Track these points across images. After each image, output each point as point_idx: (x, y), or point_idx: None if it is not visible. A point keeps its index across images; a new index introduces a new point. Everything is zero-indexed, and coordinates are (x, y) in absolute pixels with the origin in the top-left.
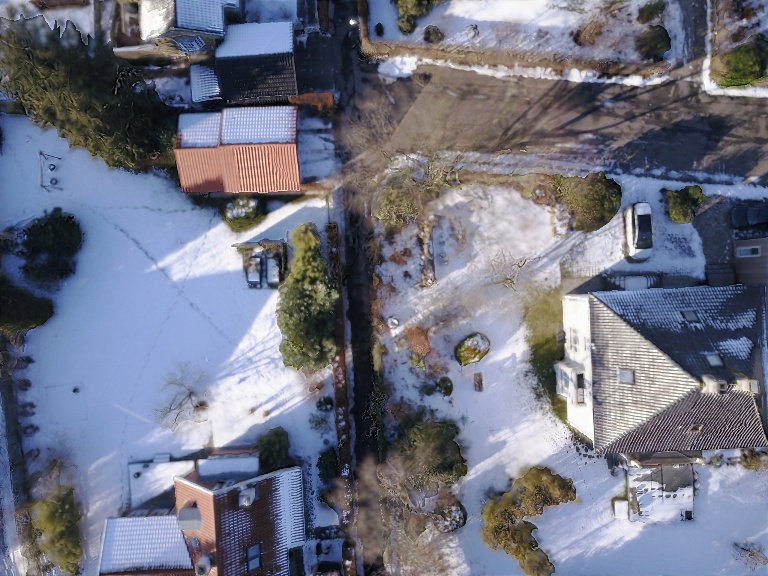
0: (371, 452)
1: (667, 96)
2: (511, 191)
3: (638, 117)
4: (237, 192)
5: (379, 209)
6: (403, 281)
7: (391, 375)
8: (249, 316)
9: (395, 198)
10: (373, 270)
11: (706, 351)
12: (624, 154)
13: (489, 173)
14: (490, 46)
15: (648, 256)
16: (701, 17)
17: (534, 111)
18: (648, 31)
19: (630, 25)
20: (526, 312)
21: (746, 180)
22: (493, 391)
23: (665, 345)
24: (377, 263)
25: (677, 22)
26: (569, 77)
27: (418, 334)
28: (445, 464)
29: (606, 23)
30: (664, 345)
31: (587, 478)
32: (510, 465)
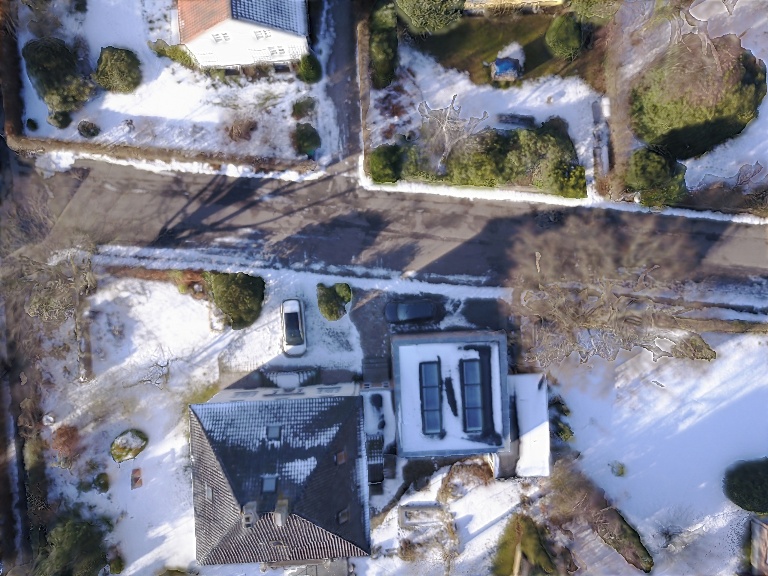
0: (40, 546)
1: (325, 191)
2: (169, 286)
3: (296, 212)
4: None
5: (29, 307)
6: (62, 377)
7: (53, 471)
8: None
9: (44, 296)
10: (34, 365)
11: (267, 474)
12: (283, 249)
13: (148, 268)
14: (146, 141)
15: (301, 352)
16: (354, 114)
17: (193, 206)
18: None
19: (285, 121)
20: (185, 407)
21: (403, 274)
22: (152, 487)
23: (231, 467)
24: (36, 359)
25: (331, 118)
26: (227, 172)
27: (60, 435)
28: (58, 575)
29: (262, 119)
30: (230, 467)
31: (248, 572)
32: (170, 560)
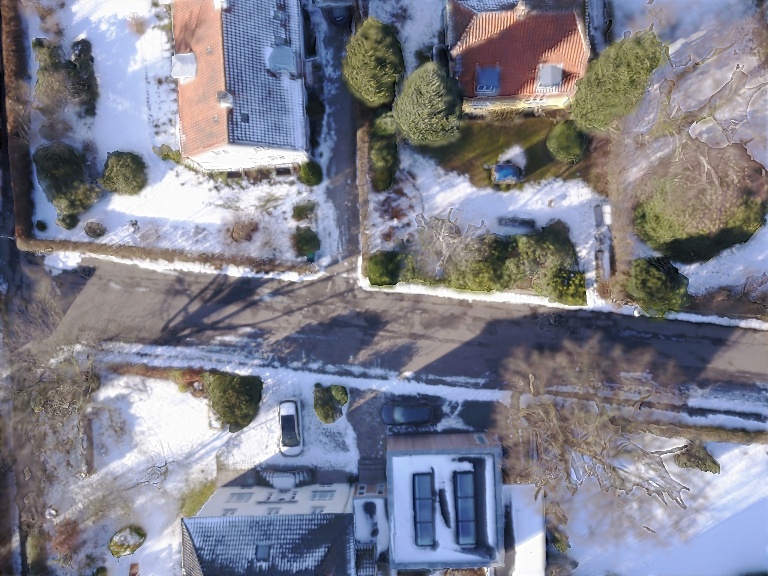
0: None
1: (324, 291)
2: (170, 383)
3: (295, 311)
4: None
5: (34, 403)
6: (66, 470)
7: None
8: None
9: None
10: (39, 457)
11: None
12: (282, 348)
13: (149, 365)
14: (150, 241)
15: (297, 453)
16: (354, 216)
17: (195, 304)
18: (296, 232)
19: (285, 222)
20: (183, 503)
21: (401, 375)
22: None
23: None
24: (41, 452)
25: (331, 220)
26: (228, 271)
27: (60, 532)
28: None
29: (262, 220)
30: None
31: None
32: None
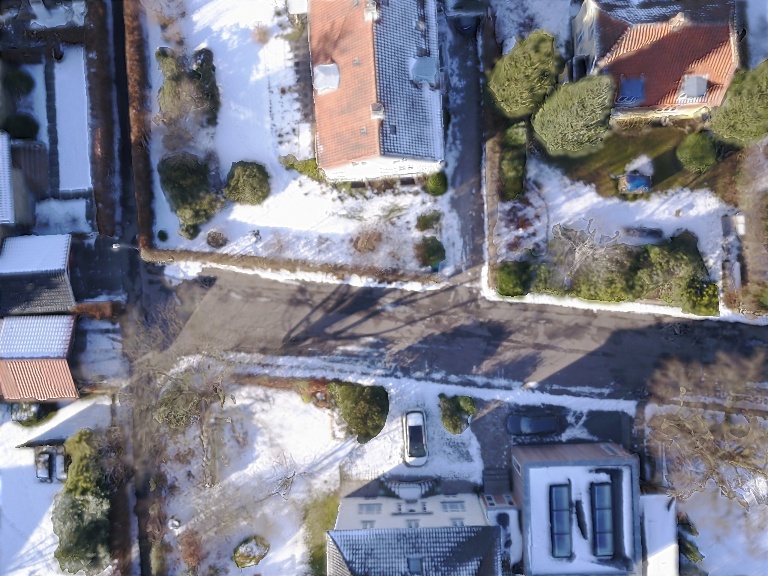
0: None
1: (447, 301)
2: (292, 394)
3: (418, 321)
4: (17, 398)
5: (158, 414)
6: (187, 480)
7: (176, 572)
8: (40, 510)
9: None
10: (159, 468)
11: None
12: (404, 358)
13: (271, 375)
14: (272, 251)
15: (423, 463)
16: (478, 226)
17: (316, 314)
18: (422, 242)
19: (409, 232)
20: (306, 514)
21: (525, 385)
22: None
23: None
24: (162, 462)
25: (455, 230)
26: (350, 281)
27: (189, 544)
28: None
29: (386, 230)
30: None
31: None
32: None
